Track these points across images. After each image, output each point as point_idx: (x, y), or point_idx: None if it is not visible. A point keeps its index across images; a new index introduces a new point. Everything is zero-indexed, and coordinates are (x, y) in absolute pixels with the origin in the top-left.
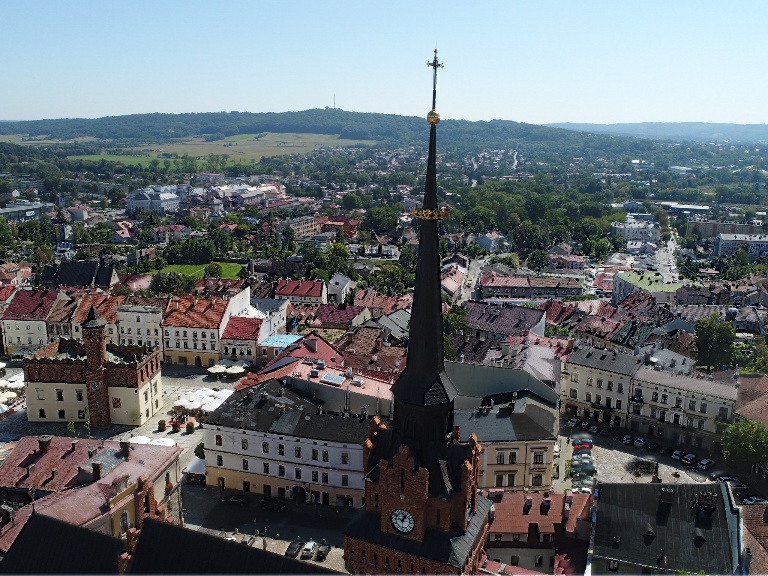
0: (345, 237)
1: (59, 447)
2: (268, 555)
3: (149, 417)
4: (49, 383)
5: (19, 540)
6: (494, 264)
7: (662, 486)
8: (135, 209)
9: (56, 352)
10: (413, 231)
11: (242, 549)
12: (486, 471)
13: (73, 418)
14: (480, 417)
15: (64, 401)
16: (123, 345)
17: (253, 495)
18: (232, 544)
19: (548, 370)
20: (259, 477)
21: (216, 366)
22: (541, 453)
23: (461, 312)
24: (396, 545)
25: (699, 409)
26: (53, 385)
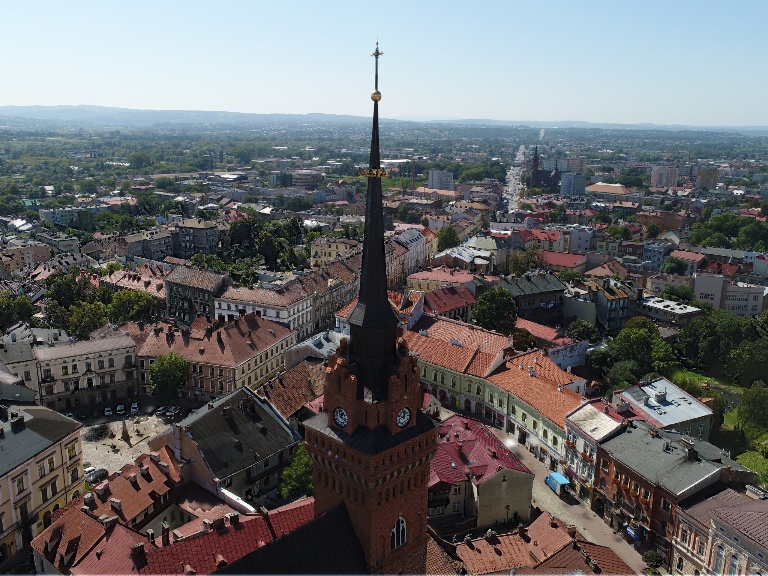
0: None
1: None
2: (259, 552)
3: None
4: None
5: None
6: None
7: (218, 408)
8: None
9: None
10: None
11: (233, 568)
12: (32, 492)
13: None
14: None
15: None
16: None
17: None
18: (221, 572)
19: (3, 374)
20: None
21: None
22: (73, 446)
23: None
24: (406, 437)
25: (108, 365)
26: None
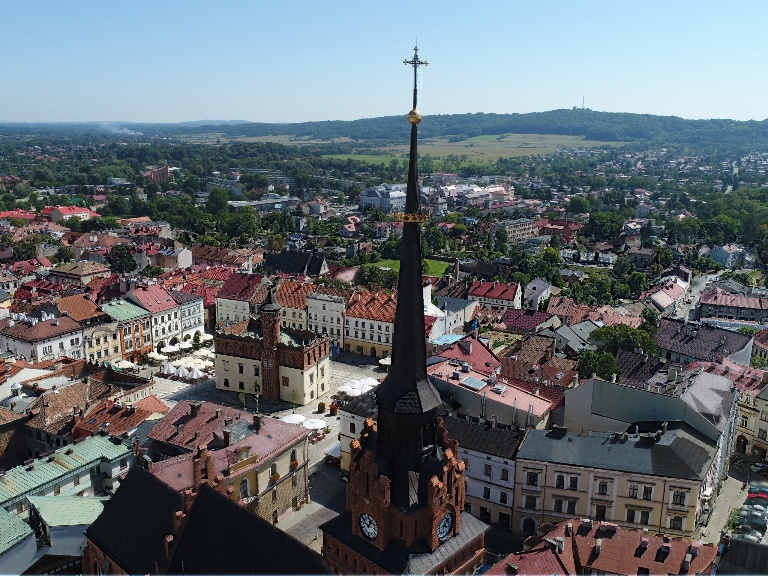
0: (560, 241)
1: (207, 413)
2: (287, 537)
3: (314, 398)
4: (233, 357)
5: (122, 485)
6: (724, 280)
7: None
8: None
9: (245, 330)
10: (638, 239)
11: (268, 527)
12: (615, 502)
13: (251, 390)
14: (615, 443)
15: (244, 374)
16: (299, 329)
17: None
18: (261, 521)
19: (714, 402)
20: None
21: (387, 358)
22: (682, 493)
23: (651, 329)
24: (361, 549)
25: None
26: (236, 359)
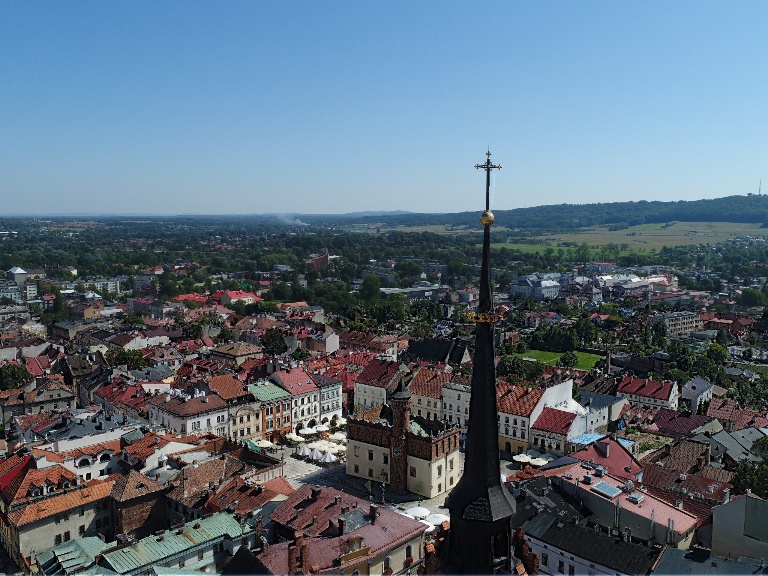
0: (728, 337)
1: (326, 498)
2: None
3: (441, 492)
4: (364, 443)
5: (230, 565)
6: None
7: None
8: (516, 294)
9: (378, 416)
10: None
11: None
12: None
13: (379, 478)
14: None
15: (374, 461)
16: (430, 419)
17: None
18: None
19: None
20: None
21: (521, 455)
22: None
23: None
24: None
25: None
26: (367, 445)
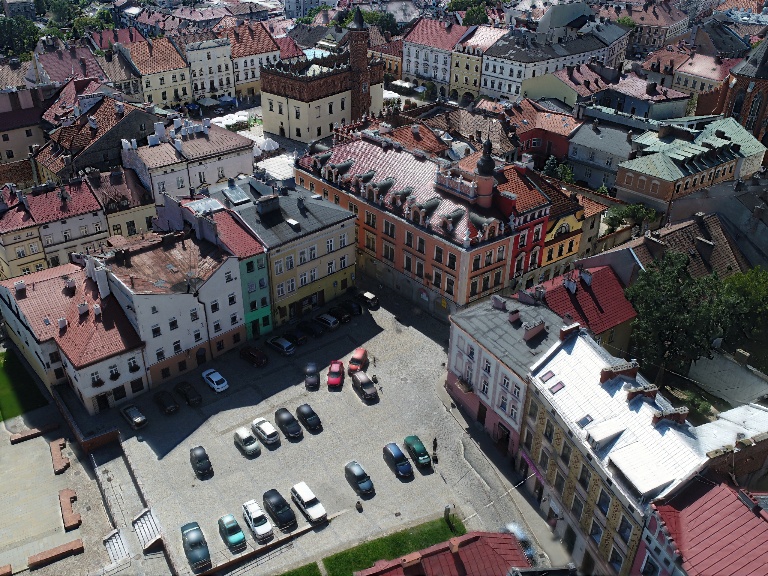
0: None
1: None
2: None
3: None
4: (325, 98)
5: None
6: (145, 7)
7: (708, 24)
8: None
9: None
10: None
11: None
12: (618, 55)
13: None
14: None
15: (333, 113)
16: (324, 57)
17: None
18: None
19: None
20: None
21: None
22: None
23: None
24: None
25: None
26: (327, 99)
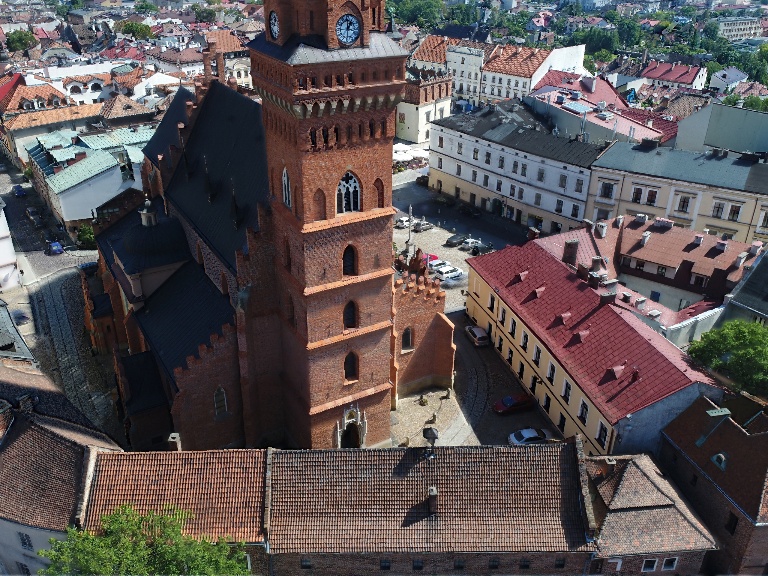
0: None
1: None
2: (260, 108)
3: None
4: None
5: (170, 106)
6: None
7: None
8: (563, 2)
9: None
10: None
11: (250, 103)
12: (695, 222)
13: None
14: (711, 159)
15: None
16: (423, 69)
17: (461, 202)
18: (246, 99)
19: None
20: (468, 184)
21: None
22: None
23: None
24: (267, 50)
25: None
26: None
